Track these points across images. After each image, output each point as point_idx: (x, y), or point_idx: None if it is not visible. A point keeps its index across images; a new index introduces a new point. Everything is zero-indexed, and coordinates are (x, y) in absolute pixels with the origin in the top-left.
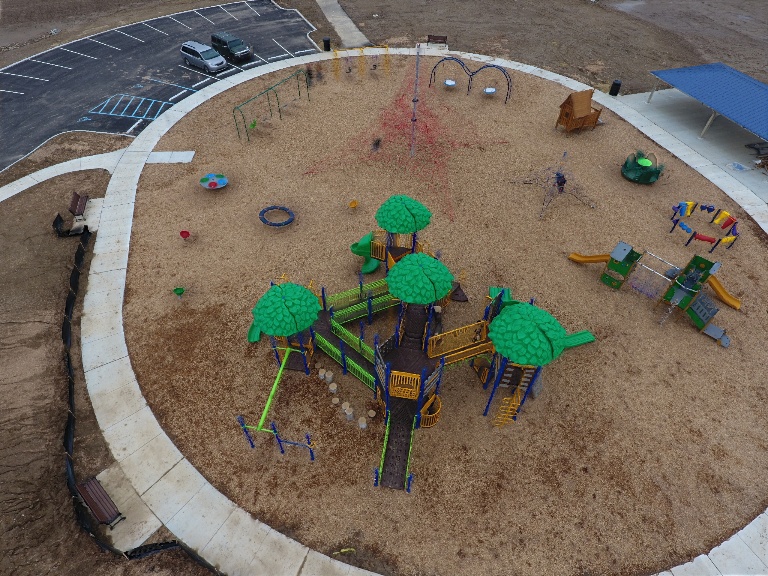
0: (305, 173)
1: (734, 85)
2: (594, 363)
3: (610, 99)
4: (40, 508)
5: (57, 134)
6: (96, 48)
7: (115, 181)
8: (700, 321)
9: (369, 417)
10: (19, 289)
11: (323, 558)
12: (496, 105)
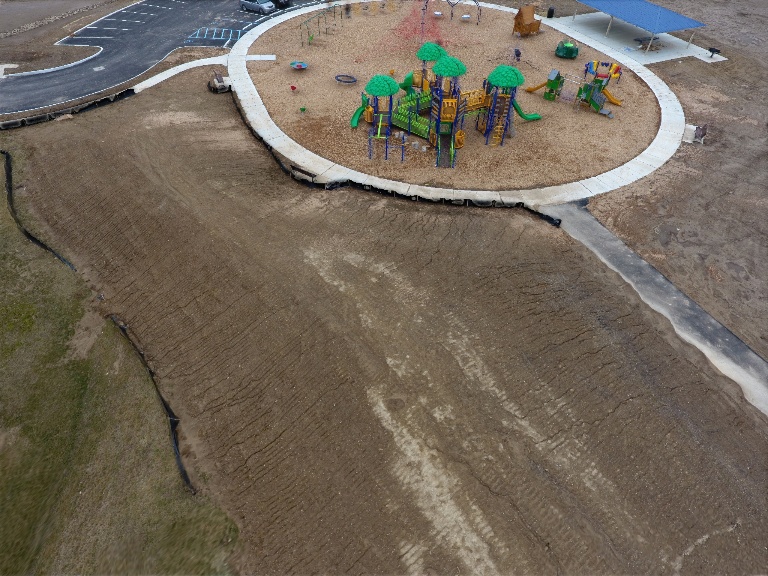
0: (354, 61)
1: (623, 0)
2: (542, 127)
3: (548, 20)
4: (275, 177)
5: (176, 48)
6: (168, 3)
7: (231, 69)
8: (597, 106)
9: (427, 148)
10: (209, 110)
11: (418, 186)
12: (471, 26)
